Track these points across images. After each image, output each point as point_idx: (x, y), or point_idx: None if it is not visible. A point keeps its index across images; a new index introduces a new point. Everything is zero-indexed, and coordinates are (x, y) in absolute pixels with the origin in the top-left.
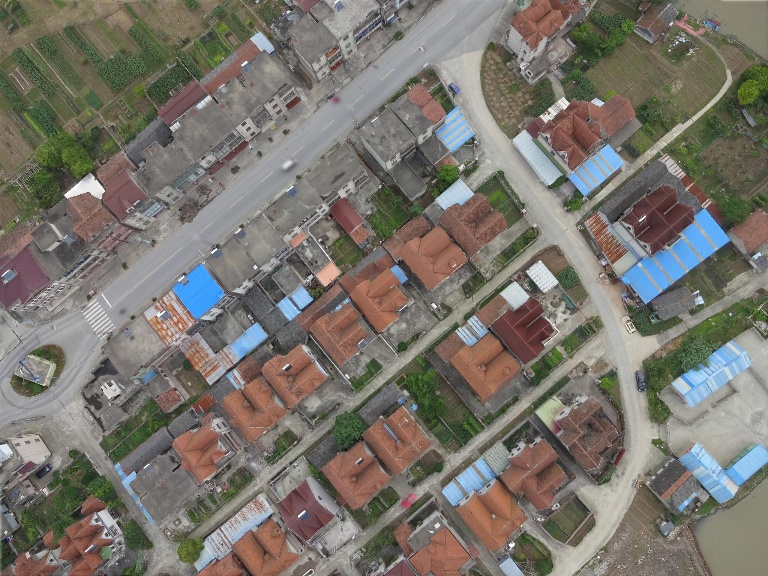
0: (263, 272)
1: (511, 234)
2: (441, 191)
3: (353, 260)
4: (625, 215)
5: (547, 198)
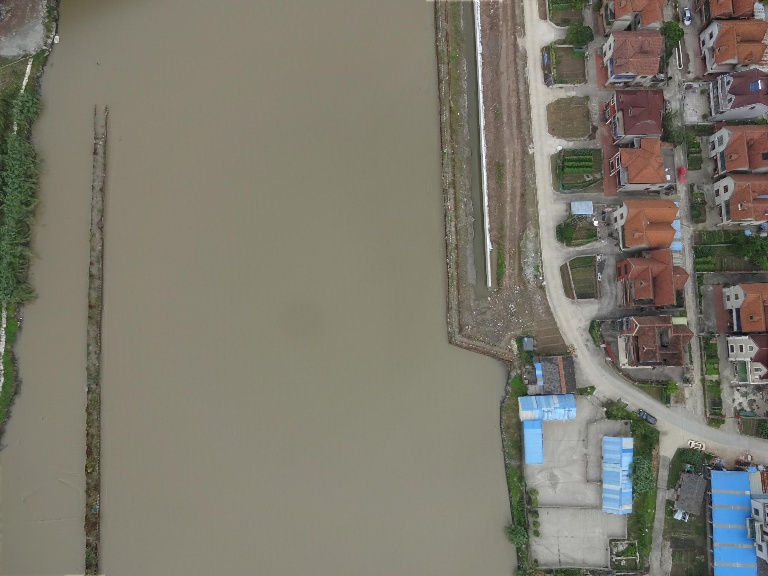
0: None
1: None
2: None
3: None
4: None
5: None
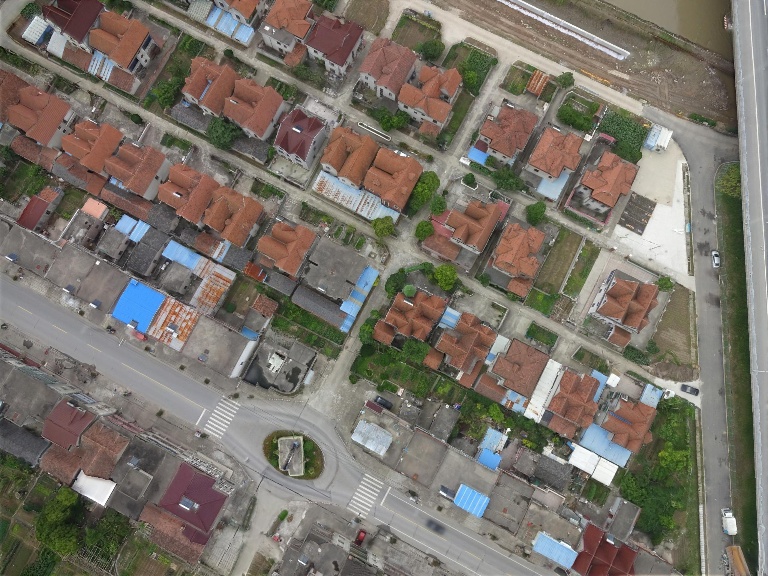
0: None
1: None
2: None
3: (78, 196)
4: None
5: None
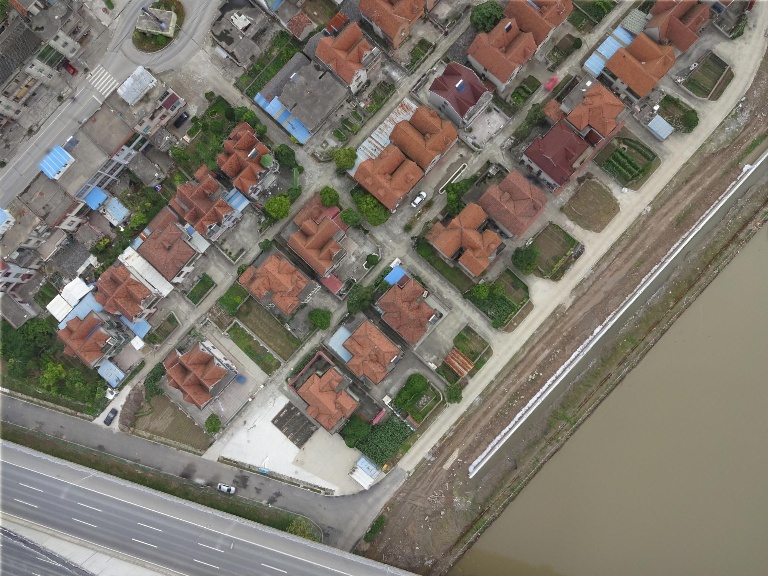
0: None
1: None
2: None
3: None
4: None
5: None
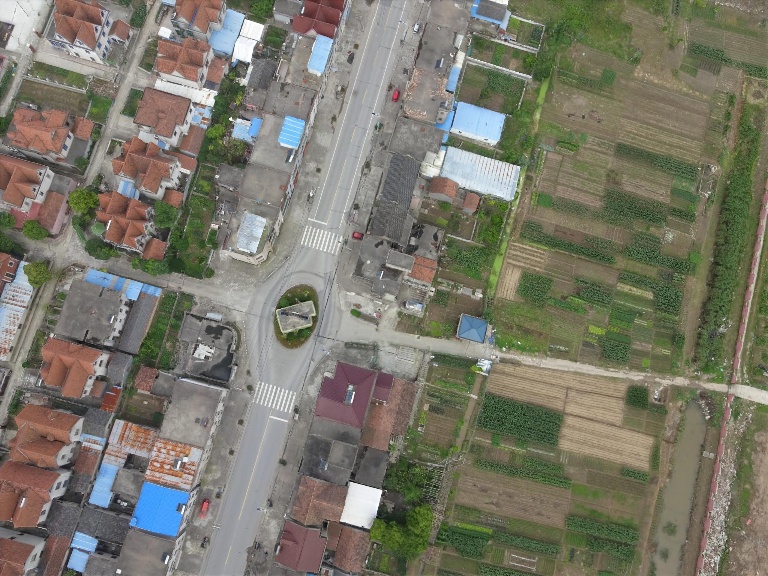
0: None
1: None
2: None
3: None
4: None
5: None
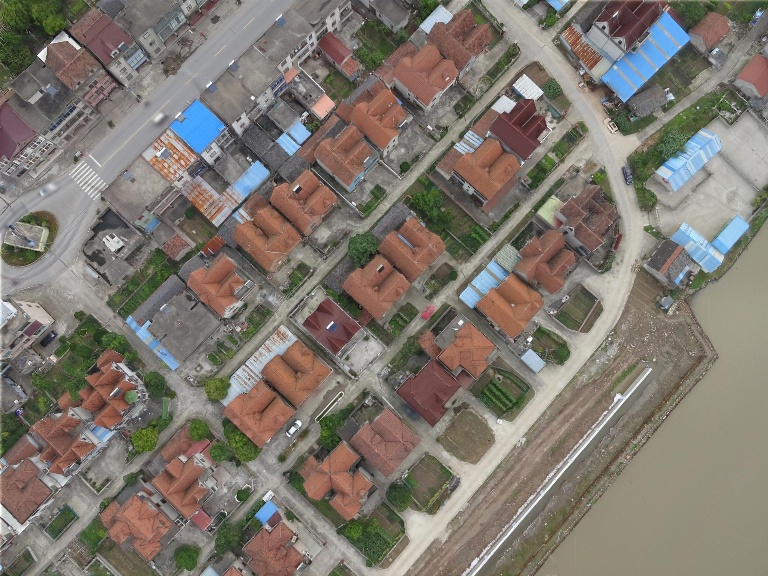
0: (258, 110)
1: (493, 55)
2: (423, 18)
3: (345, 94)
4: (599, 15)
5: (523, 19)
